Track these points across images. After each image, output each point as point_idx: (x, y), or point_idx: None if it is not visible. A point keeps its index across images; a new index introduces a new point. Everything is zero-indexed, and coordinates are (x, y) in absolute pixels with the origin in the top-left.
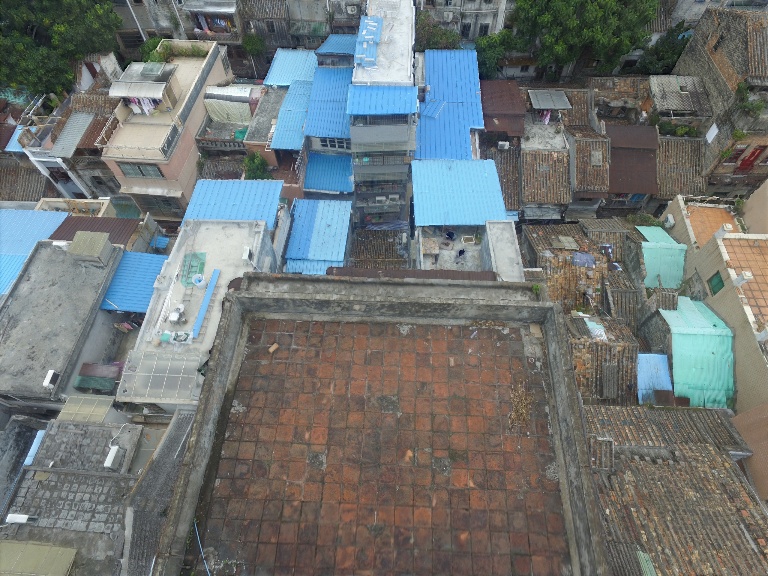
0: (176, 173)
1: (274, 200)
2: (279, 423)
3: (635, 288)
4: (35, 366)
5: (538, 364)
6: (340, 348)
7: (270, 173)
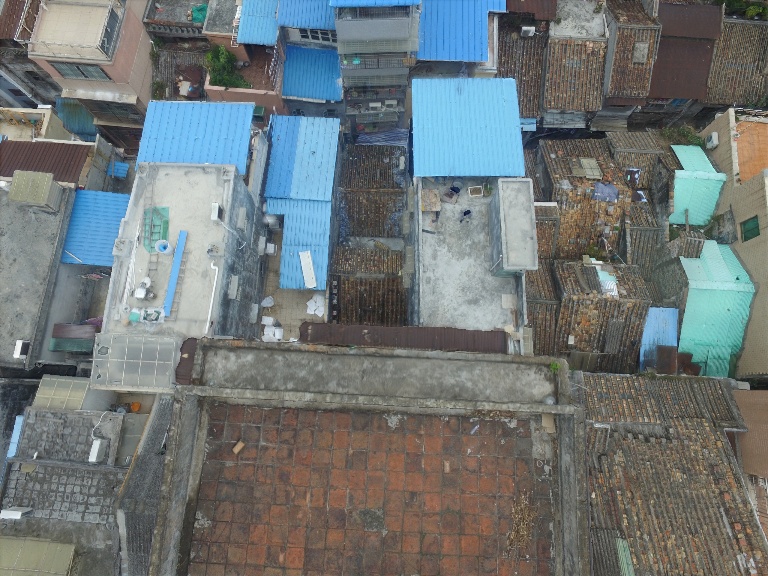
0: (125, 75)
1: (244, 133)
2: (249, 542)
3: (657, 225)
4: (2, 332)
5: (547, 469)
6: (317, 446)
7: (241, 71)
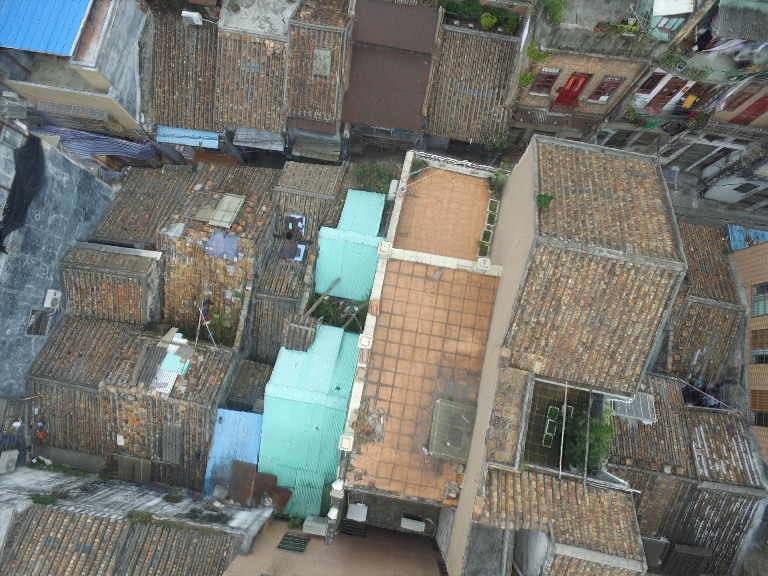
0: None
1: None
2: None
3: (298, 295)
4: None
5: None
6: None
7: None
